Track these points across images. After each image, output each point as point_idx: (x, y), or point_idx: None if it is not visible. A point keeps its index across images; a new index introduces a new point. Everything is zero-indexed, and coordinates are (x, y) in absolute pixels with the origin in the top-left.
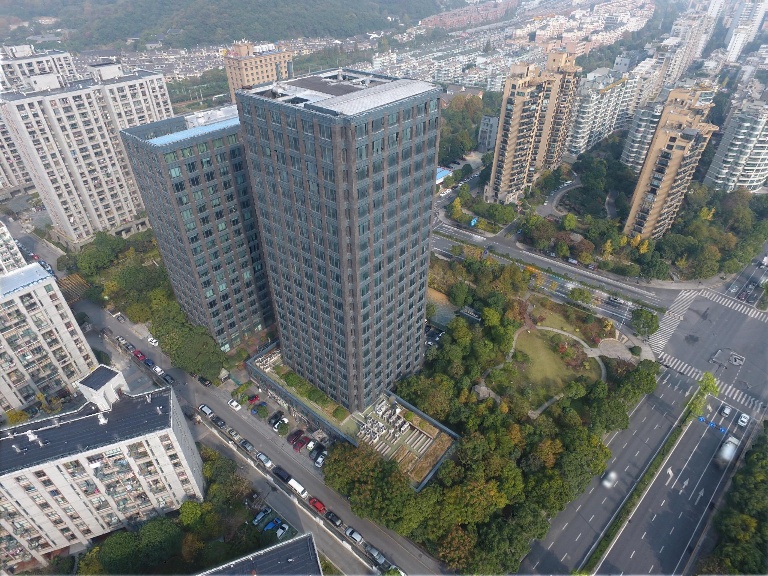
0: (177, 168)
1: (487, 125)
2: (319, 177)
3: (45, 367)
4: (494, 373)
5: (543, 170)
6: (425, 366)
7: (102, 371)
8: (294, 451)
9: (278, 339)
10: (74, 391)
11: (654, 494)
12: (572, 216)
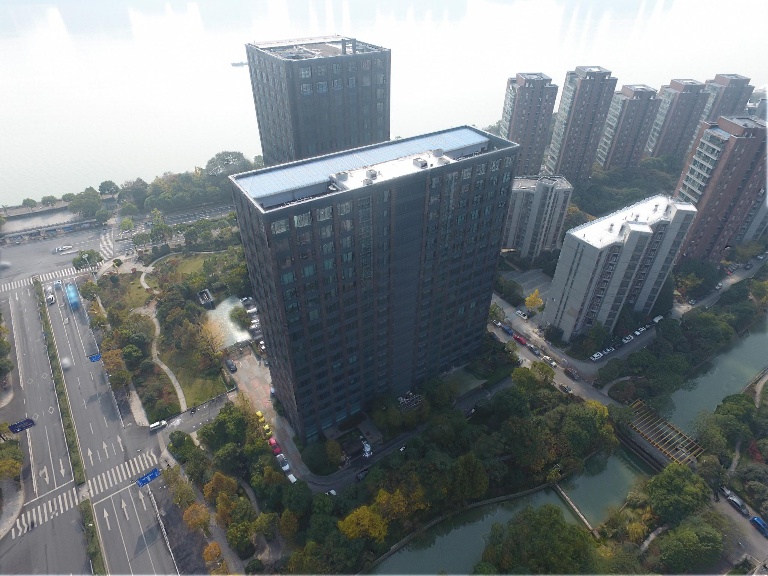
0: None
1: None
2: None
3: None
4: None
5: None
6: None
7: None
8: None
9: None
10: None
11: None
12: None
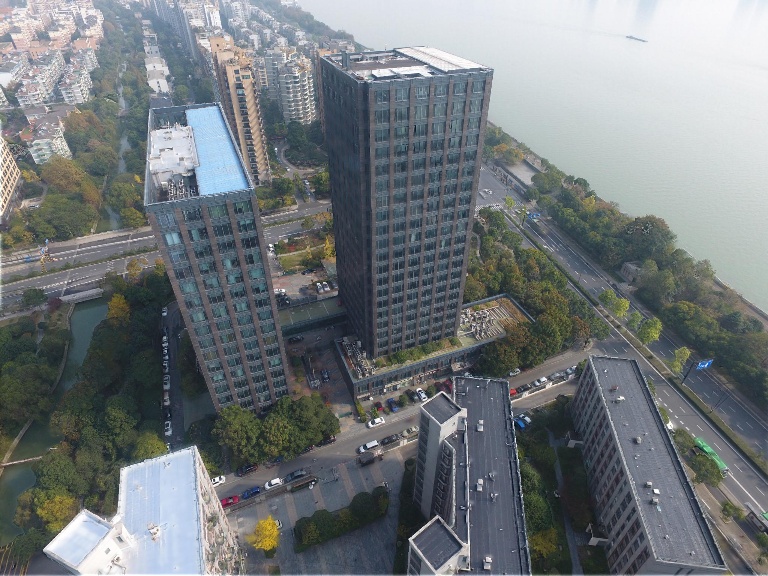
0: None
1: None
2: (464, 129)
3: None
4: None
5: None
6: None
7: (429, 407)
8: None
9: (309, 369)
10: None
11: (556, 258)
12: None
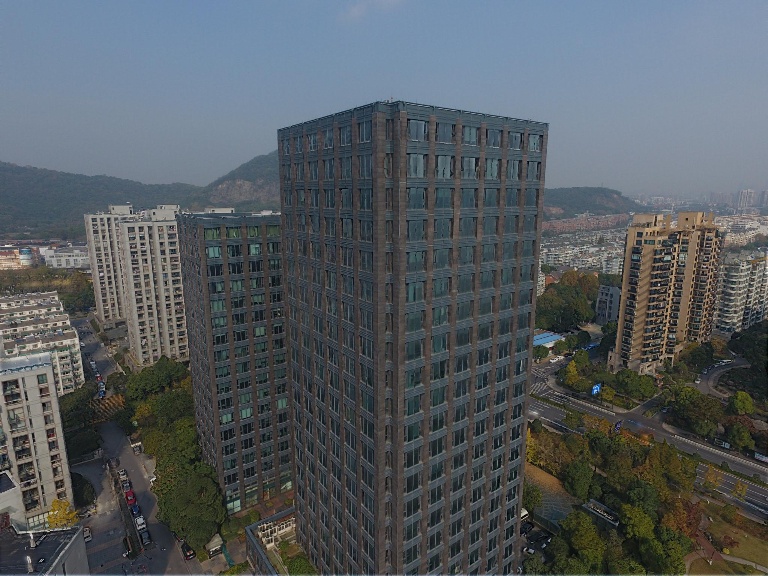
0: (217, 248)
1: (606, 295)
2: (354, 206)
3: None
4: None
5: (687, 342)
6: None
7: None
8: None
9: None
10: None
11: None
12: (746, 395)
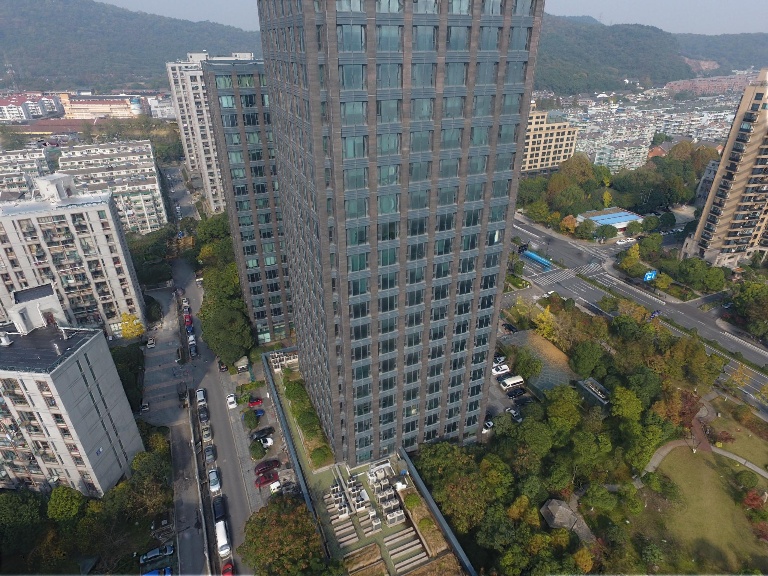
0: (231, 97)
1: None
2: (296, 48)
3: (86, 297)
4: (594, 491)
5: None
6: (491, 441)
7: (46, 289)
8: (254, 485)
9: None
10: (111, 334)
11: None
12: None
